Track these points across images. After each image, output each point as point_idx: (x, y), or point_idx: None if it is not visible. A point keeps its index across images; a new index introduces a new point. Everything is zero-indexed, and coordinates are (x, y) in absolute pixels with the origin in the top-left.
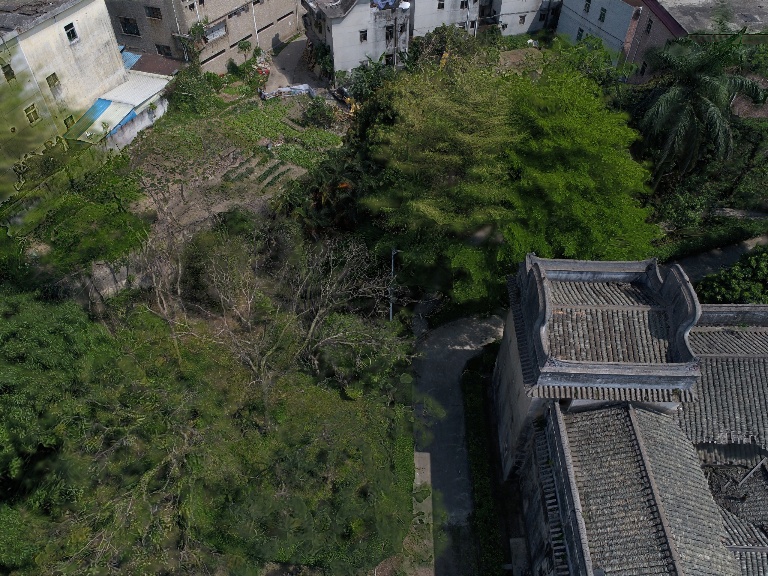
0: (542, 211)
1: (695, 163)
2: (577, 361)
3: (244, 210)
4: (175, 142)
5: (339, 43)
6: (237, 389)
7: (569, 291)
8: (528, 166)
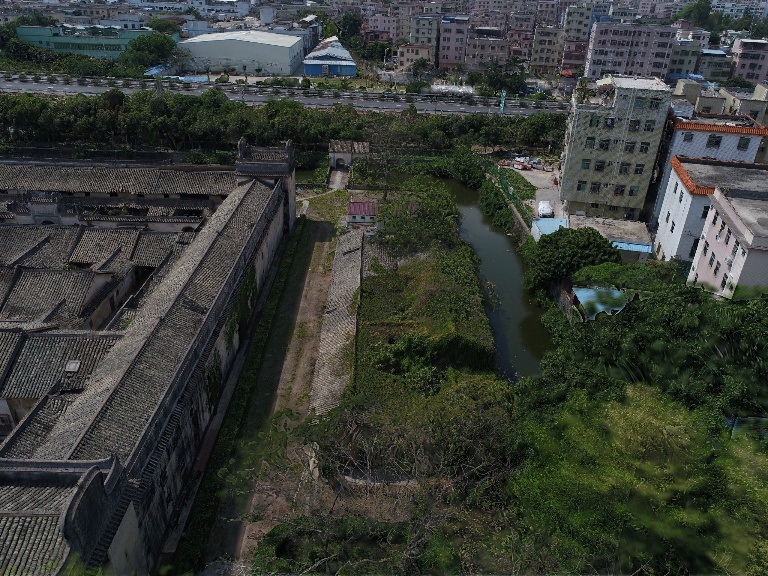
0: None
1: None
2: (89, 461)
3: None
4: None
5: None
6: None
7: (18, 569)
8: None
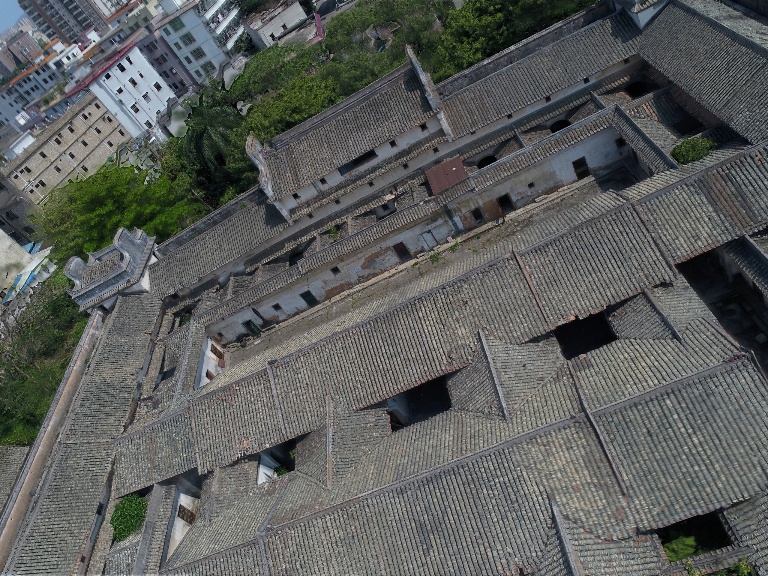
0: (96, 231)
1: None
2: None
3: (62, 296)
4: (60, 279)
5: None
6: (55, 379)
7: None
8: (83, 215)
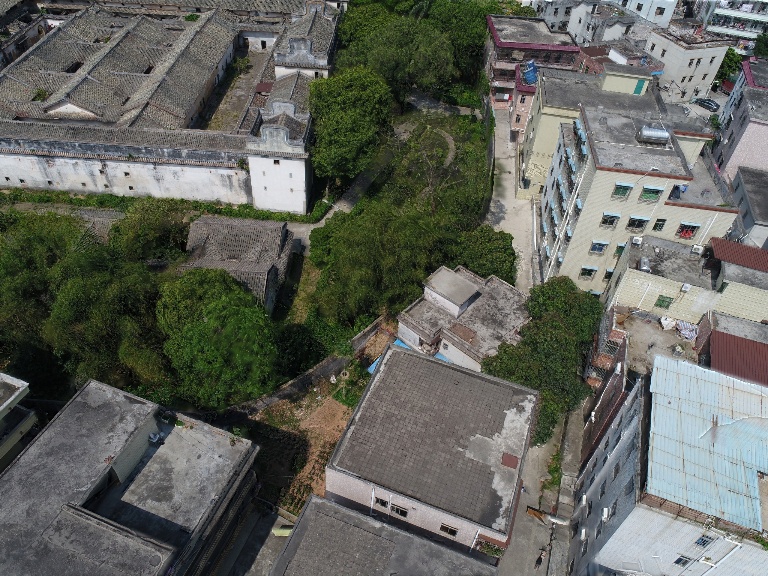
0: None
1: None
2: None
3: None
4: None
5: (524, 1)
6: None
7: None
8: None
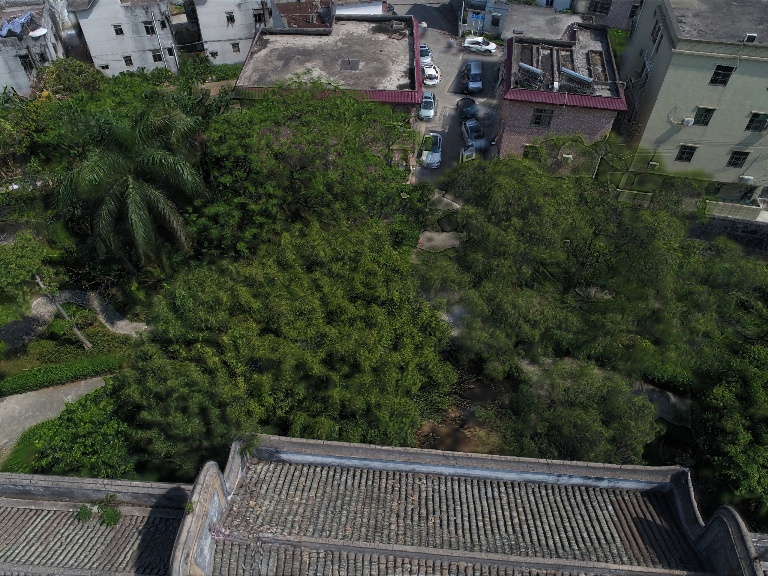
0: None
1: (151, 251)
2: None
3: None
4: None
5: None
6: None
7: None
8: None
